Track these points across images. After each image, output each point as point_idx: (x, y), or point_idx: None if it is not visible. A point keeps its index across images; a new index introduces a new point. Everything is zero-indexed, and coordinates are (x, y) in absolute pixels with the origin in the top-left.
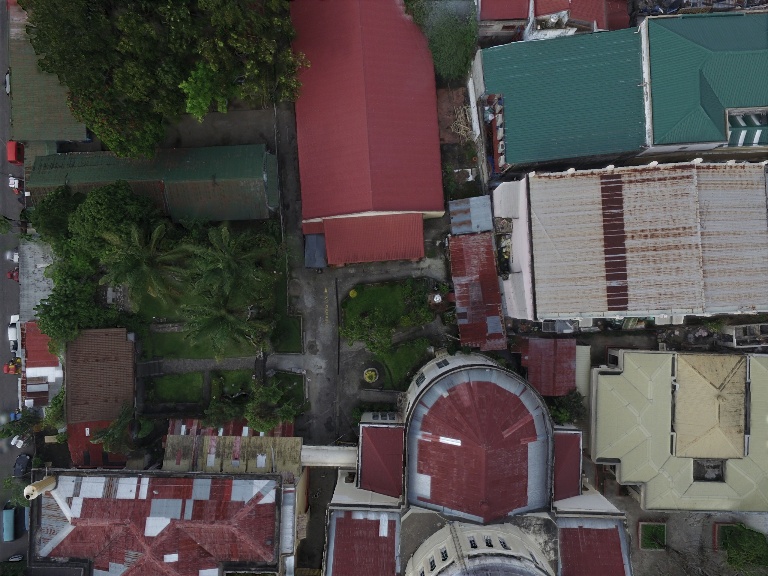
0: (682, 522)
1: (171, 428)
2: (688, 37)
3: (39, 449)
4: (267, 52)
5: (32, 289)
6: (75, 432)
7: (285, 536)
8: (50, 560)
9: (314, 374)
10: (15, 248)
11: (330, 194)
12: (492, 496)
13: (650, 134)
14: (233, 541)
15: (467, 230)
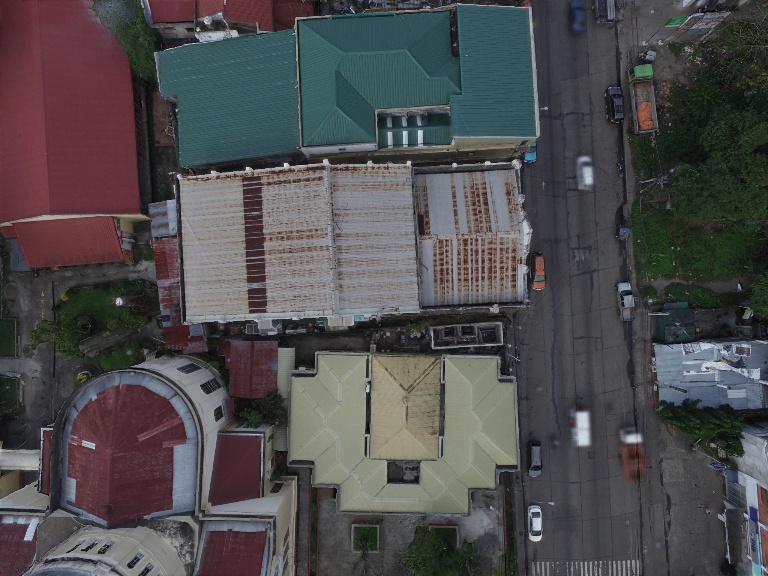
0: (397, 524)
1: None
2: (328, 38)
3: None
4: None
5: None
6: None
7: None
8: None
9: (30, 378)
10: None
11: (18, 198)
12: (120, 500)
13: (300, 136)
14: None
15: (165, 233)
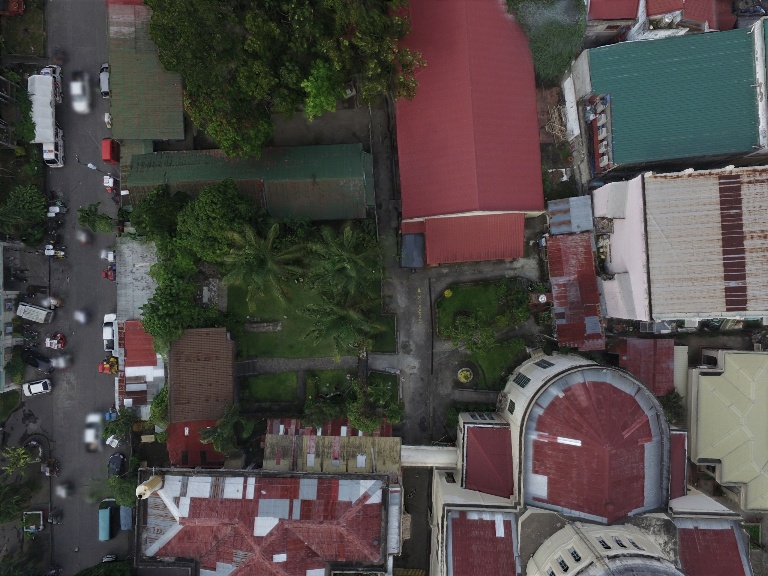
0: None
1: (269, 428)
2: None
3: (135, 448)
4: (390, 51)
5: (130, 288)
6: (174, 432)
7: (391, 536)
8: (156, 560)
9: (408, 374)
10: (108, 247)
11: (433, 194)
12: (614, 496)
13: (765, 134)
14: (341, 541)
15: (567, 230)
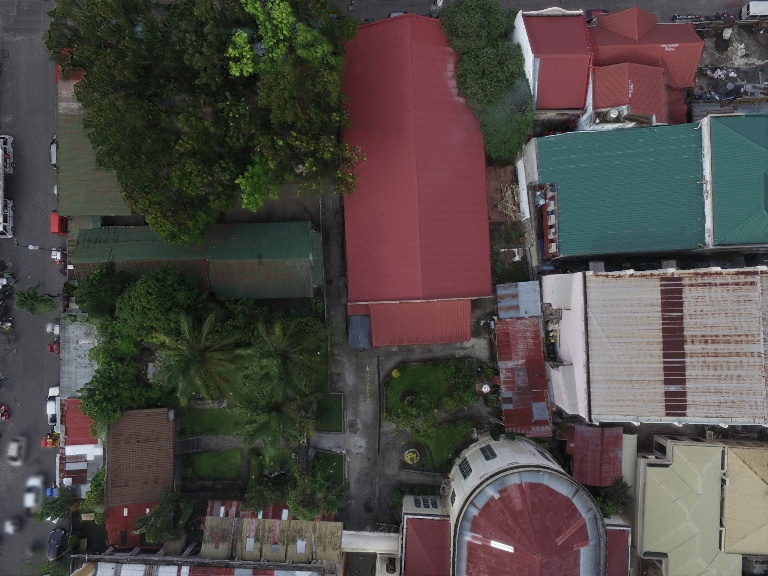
0: None
1: (210, 509)
2: (752, 138)
3: (75, 525)
4: (325, 149)
5: (73, 365)
6: (113, 512)
7: None
8: None
9: (354, 453)
10: (55, 319)
11: (378, 278)
12: None
13: (710, 234)
14: None
15: (515, 315)
